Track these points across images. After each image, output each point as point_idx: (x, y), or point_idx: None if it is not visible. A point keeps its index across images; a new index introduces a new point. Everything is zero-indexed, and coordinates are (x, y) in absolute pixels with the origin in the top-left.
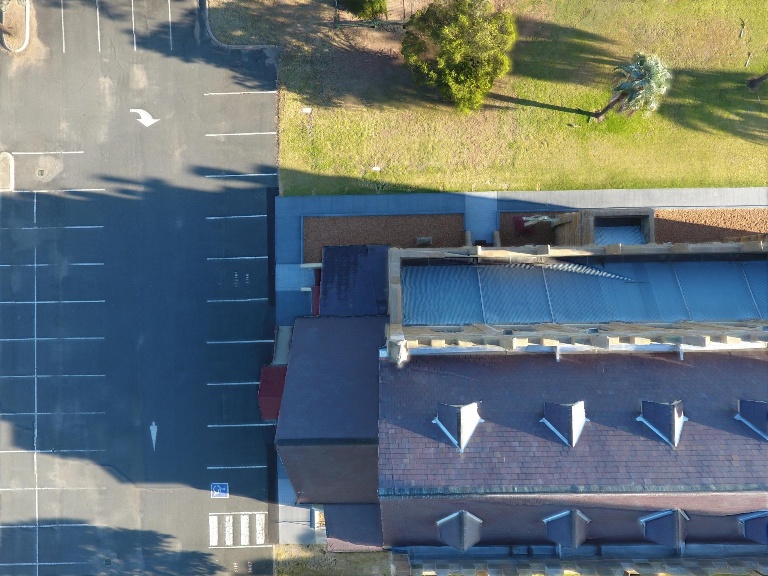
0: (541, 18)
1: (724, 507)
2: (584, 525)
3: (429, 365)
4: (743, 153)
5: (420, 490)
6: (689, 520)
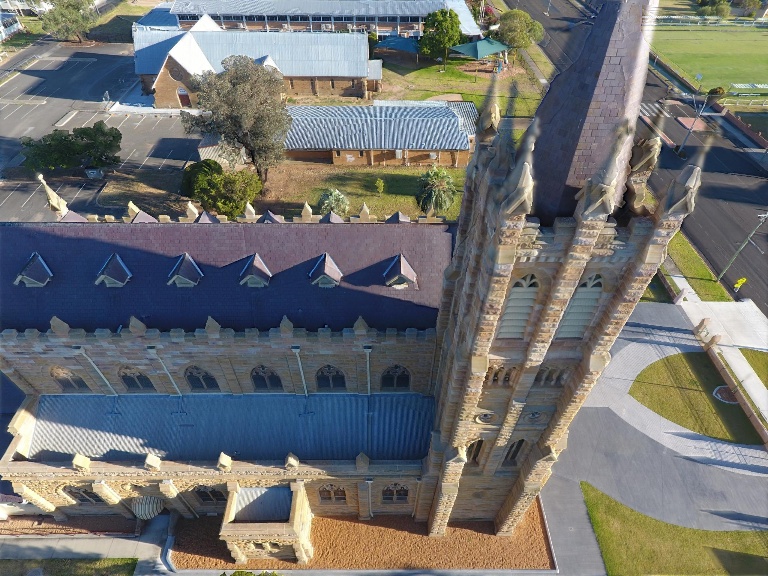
0: (302, 202)
1: (215, 249)
2: (124, 274)
3: None
4: None
5: None
6: (204, 276)
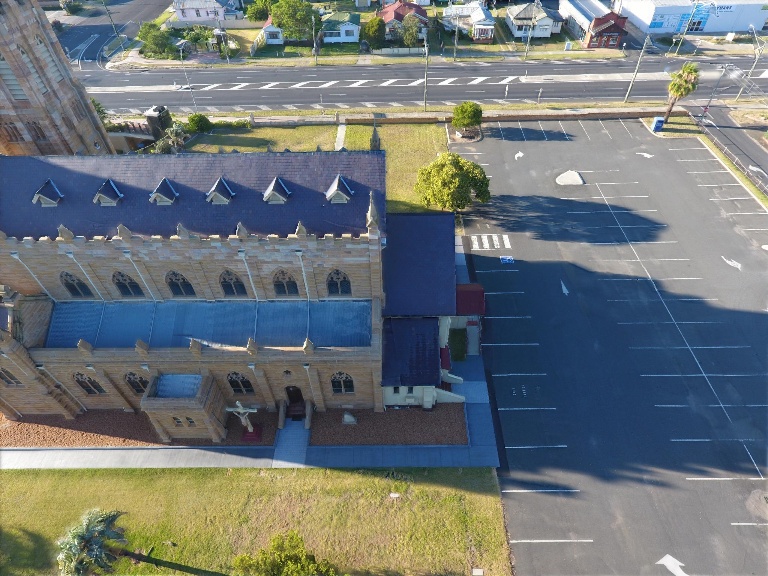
0: None
1: None
2: None
3: (354, 232)
4: (6, 507)
5: (363, 153)
6: None
